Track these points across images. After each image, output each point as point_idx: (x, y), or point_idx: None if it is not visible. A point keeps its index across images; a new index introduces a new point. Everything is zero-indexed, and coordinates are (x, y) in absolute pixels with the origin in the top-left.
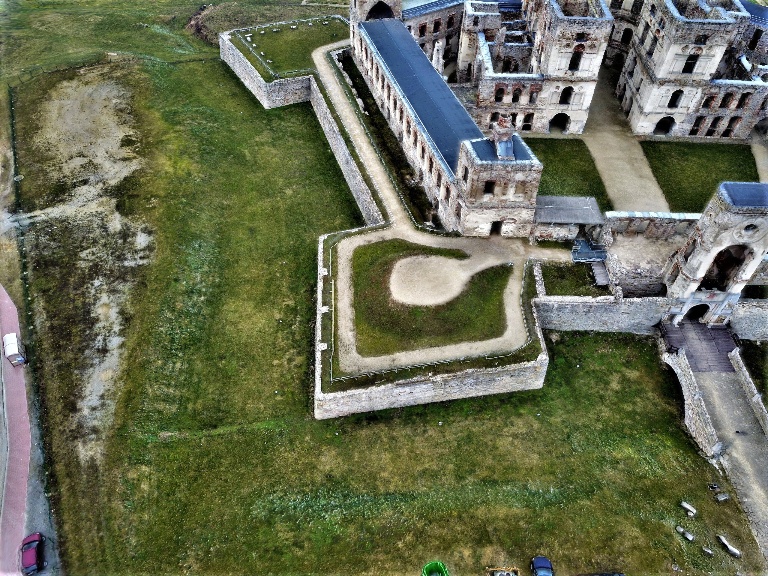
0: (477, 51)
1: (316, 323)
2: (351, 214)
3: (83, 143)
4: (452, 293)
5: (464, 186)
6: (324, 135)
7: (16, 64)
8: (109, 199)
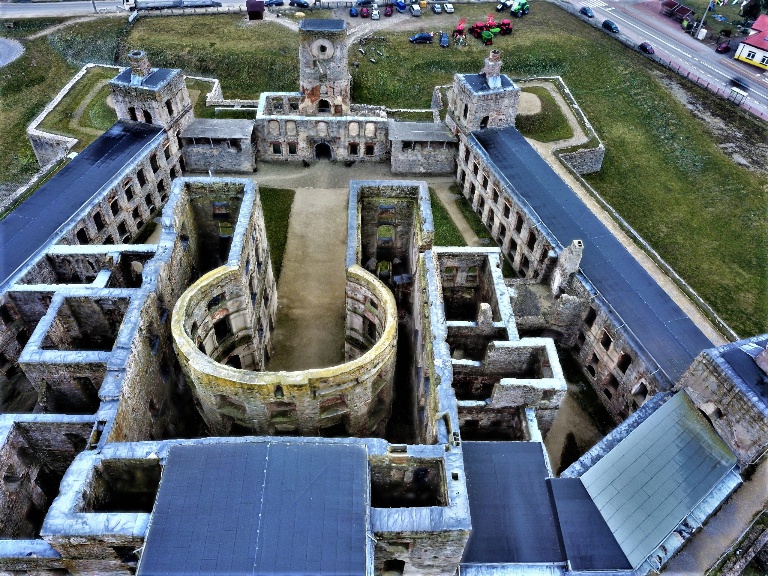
0: None
1: None
2: None
3: None
4: None
5: None
6: None
7: None
8: None
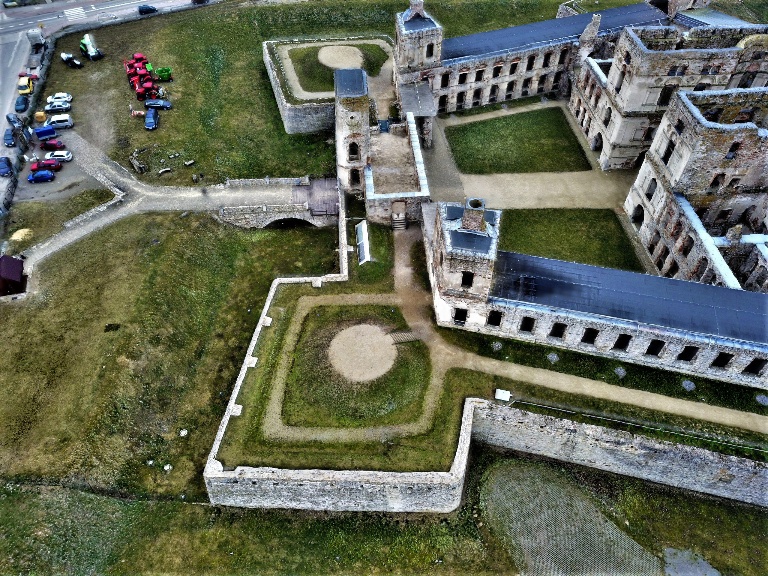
0: None
1: None
2: None
3: None
4: (329, 64)
5: None
6: None
7: None
8: None
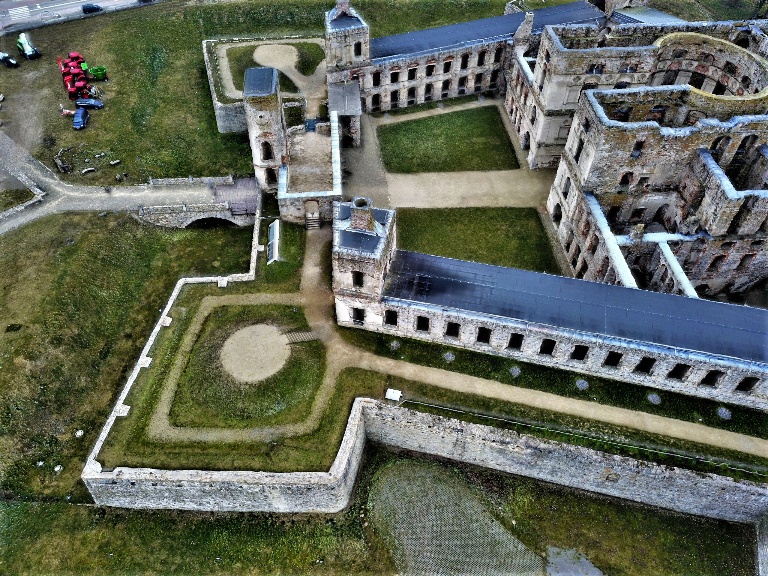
0: None
1: None
2: None
3: None
4: (263, 63)
5: None
6: None
7: None
8: None
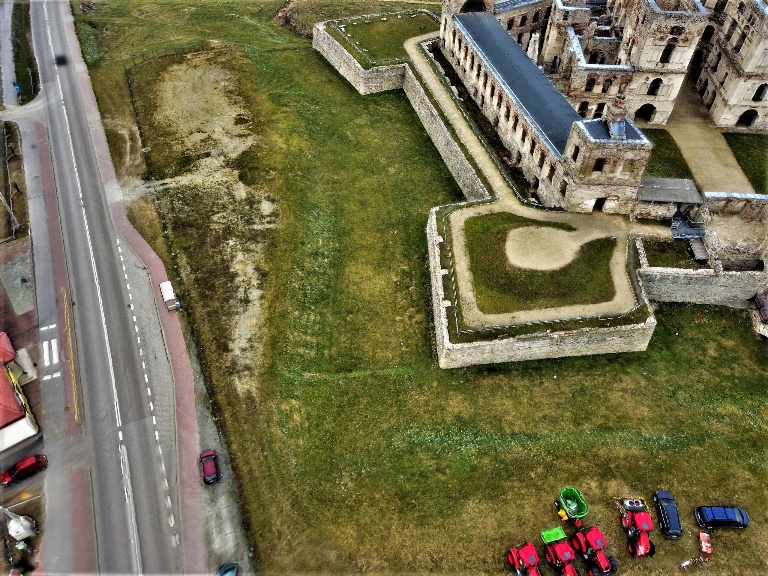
0: (565, 44)
1: (437, 283)
2: (452, 191)
3: (200, 120)
4: (564, 260)
5: (572, 164)
6: (419, 120)
7: (124, 49)
8: (232, 170)
